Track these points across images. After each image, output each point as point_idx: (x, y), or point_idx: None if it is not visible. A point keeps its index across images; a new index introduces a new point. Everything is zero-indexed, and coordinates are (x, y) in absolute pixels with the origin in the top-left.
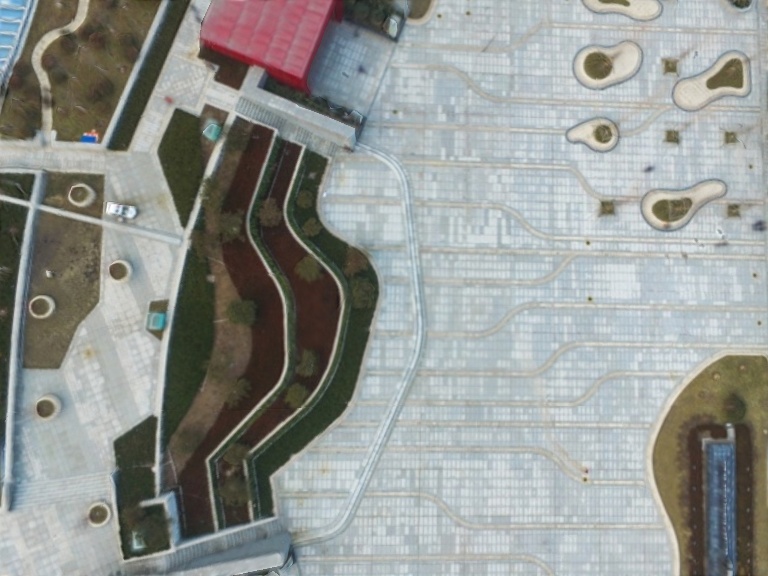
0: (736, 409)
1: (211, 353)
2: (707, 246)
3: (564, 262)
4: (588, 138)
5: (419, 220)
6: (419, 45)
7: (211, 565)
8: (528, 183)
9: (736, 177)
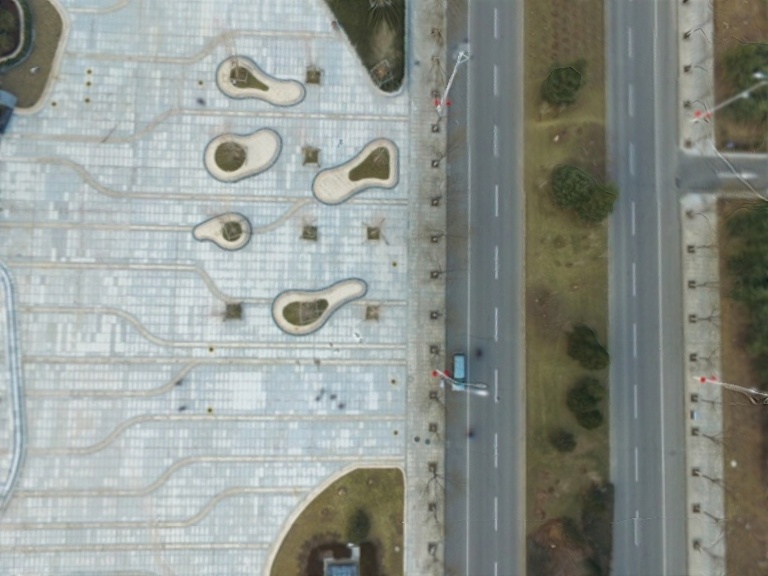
0: (357, 528)
1: None
2: (343, 351)
3: (183, 371)
4: (216, 235)
5: (23, 328)
6: (29, 136)
7: None
8: (148, 285)
9: (378, 276)
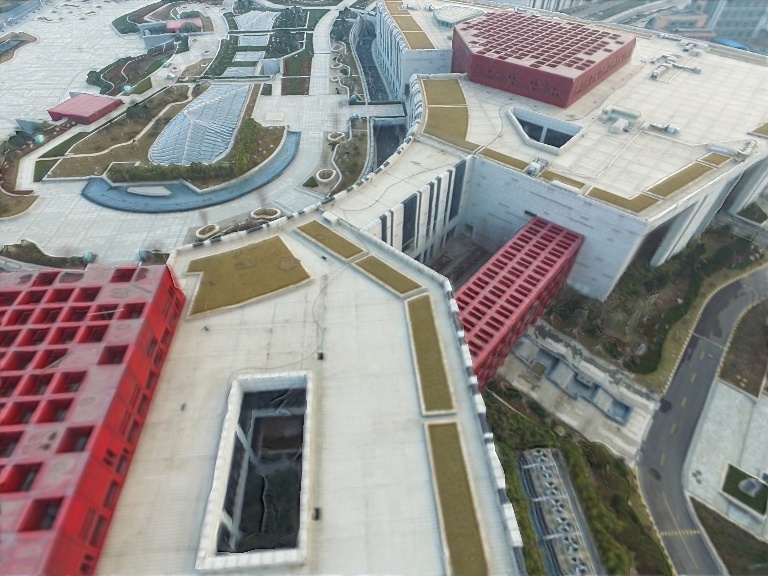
0: None
1: None
2: None
3: (7, 88)
4: None
5: None
6: None
7: (163, 35)
8: (6, 102)
9: None
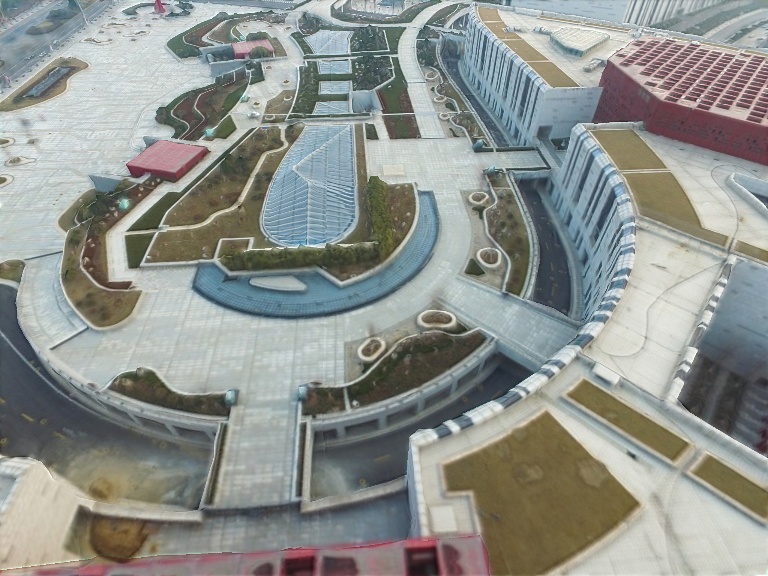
0: (17, 99)
1: None
2: None
3: None
4: None
5: (129, 135)
6: None
7: (233, 62)
8: None
9: None
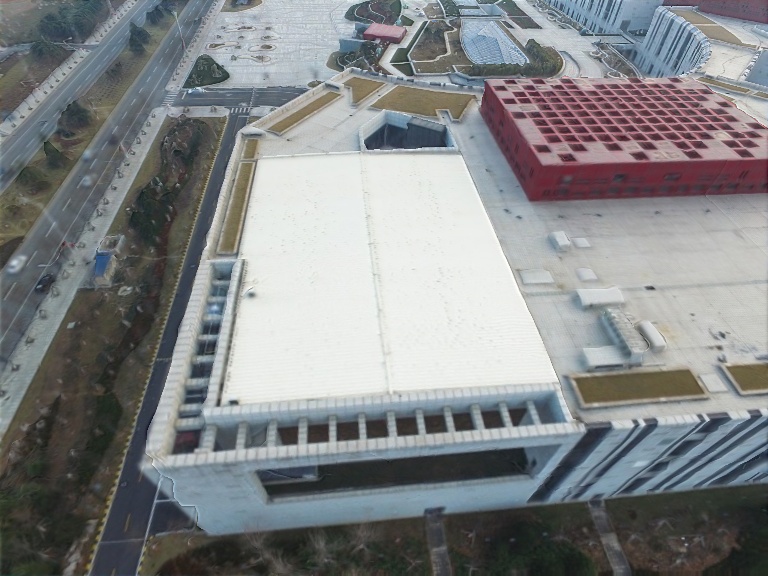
0: (235, 5)
1: (390, 6)
2: (234, 24)
3: None
4: None
5: None
6: None
7: None
8: None
9: None
